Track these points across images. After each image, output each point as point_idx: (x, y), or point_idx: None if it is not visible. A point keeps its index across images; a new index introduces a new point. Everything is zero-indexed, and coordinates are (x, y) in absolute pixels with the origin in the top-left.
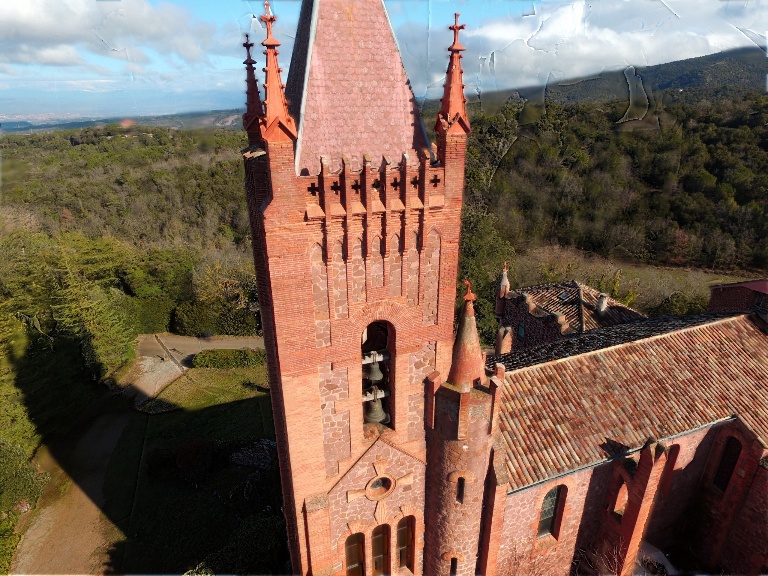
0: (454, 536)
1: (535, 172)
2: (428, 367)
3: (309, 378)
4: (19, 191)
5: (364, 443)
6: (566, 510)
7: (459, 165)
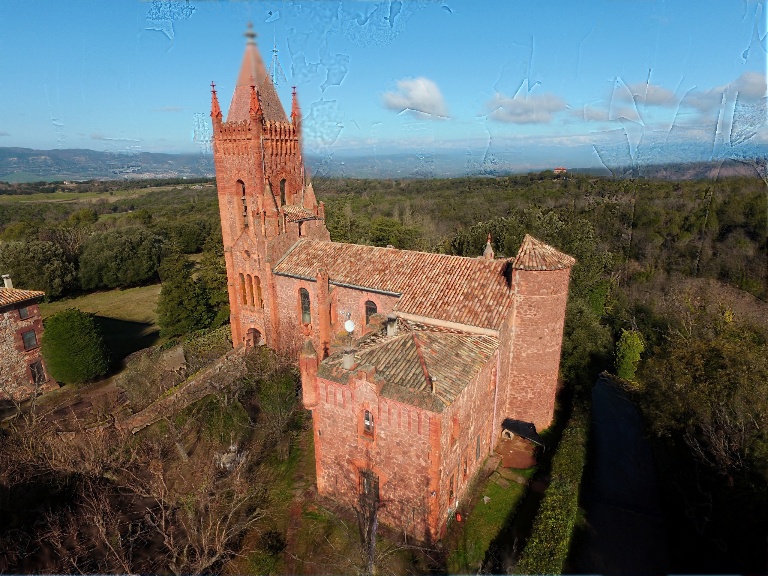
0: (261, 287)
1: (758, 203)
2: (256, 205)
3: (224, 196)
4: (345, 180)
5: (240, 231)
6: (312, 309)
7: (255, 124)
